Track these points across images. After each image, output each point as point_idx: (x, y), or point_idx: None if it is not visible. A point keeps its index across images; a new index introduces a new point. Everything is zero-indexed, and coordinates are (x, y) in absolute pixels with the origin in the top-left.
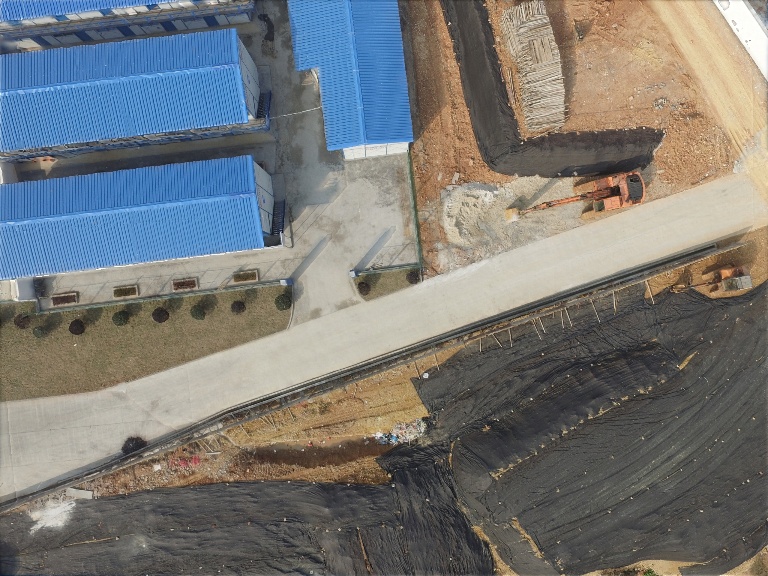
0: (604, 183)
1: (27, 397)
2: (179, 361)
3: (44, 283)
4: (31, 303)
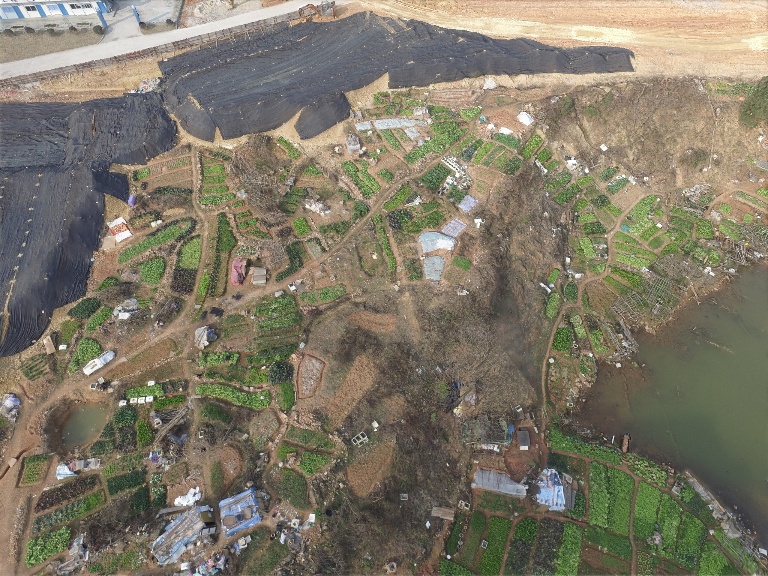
0: None
1: None
2: (30, 56)
3: None
4: None
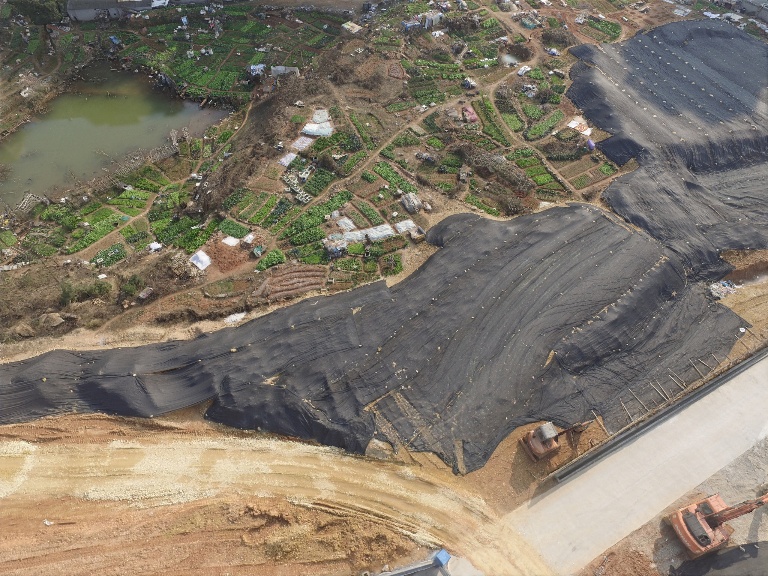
0: (722, 534)
1: None
2: None
3: None
4: None
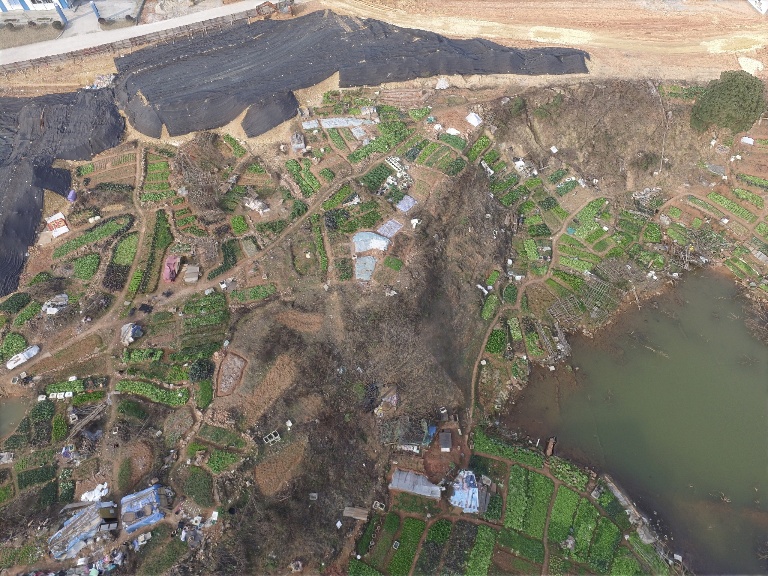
0: None
1: None
2: None
3: None
4: None
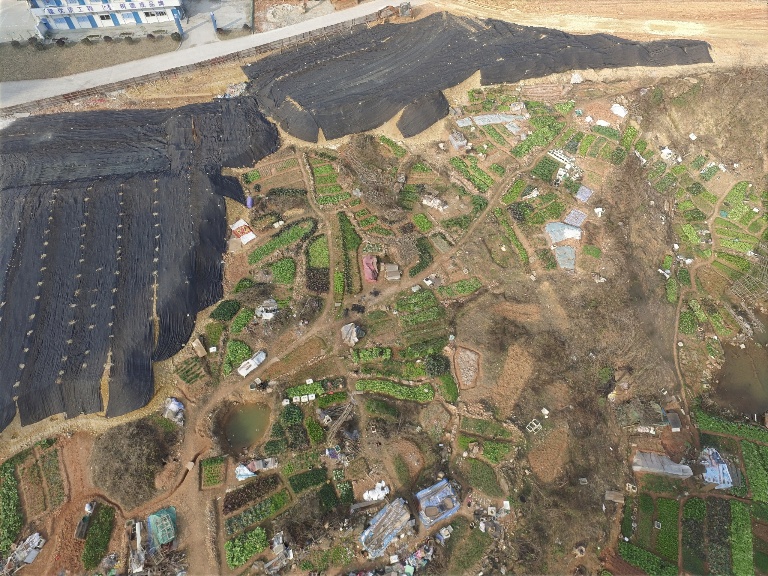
0: None
1: (14, 80)
2: (110, 65)
3: (51, 34)
4: (40, 40)
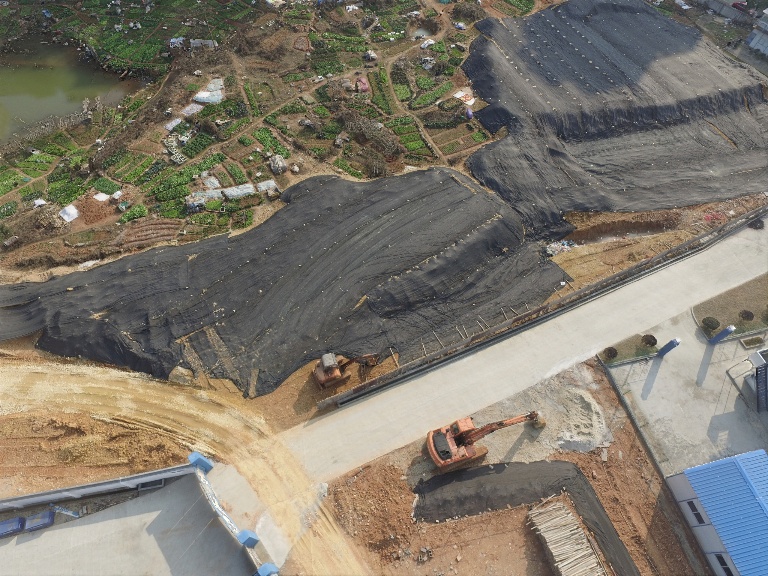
0: (469, 452)
1: None
2: (762, 279)
3: None
4: None
